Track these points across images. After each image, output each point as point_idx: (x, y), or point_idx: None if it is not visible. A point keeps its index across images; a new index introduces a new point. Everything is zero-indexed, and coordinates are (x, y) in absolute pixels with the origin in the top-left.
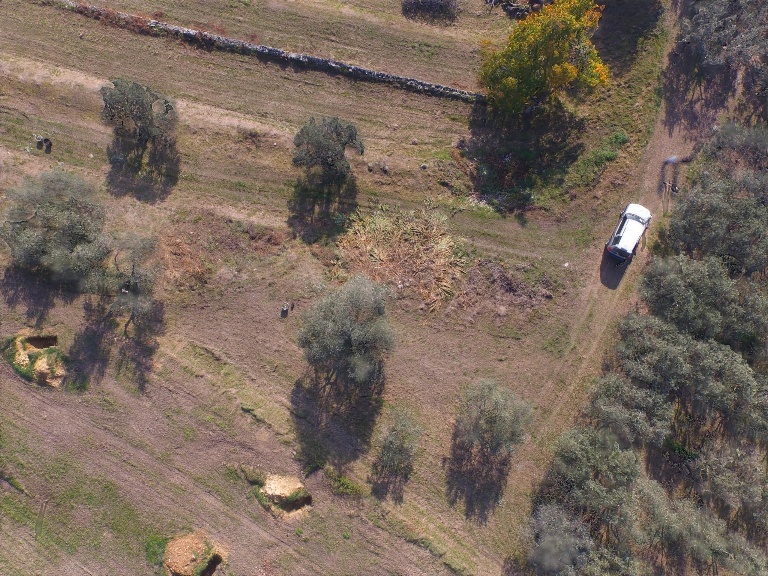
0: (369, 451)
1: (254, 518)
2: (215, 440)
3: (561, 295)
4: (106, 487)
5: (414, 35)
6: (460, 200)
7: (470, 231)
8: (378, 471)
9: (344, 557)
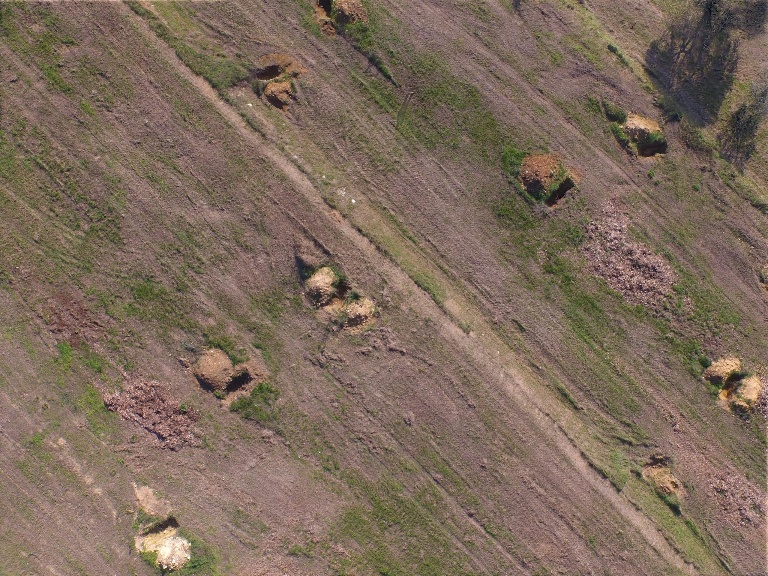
0: (715, 123)
1: (609, 152)
2: (580, 70)
3: None
4: (470, 92)
5: None
6: None
7: None
8: (721, 143)
9: (691, 207)
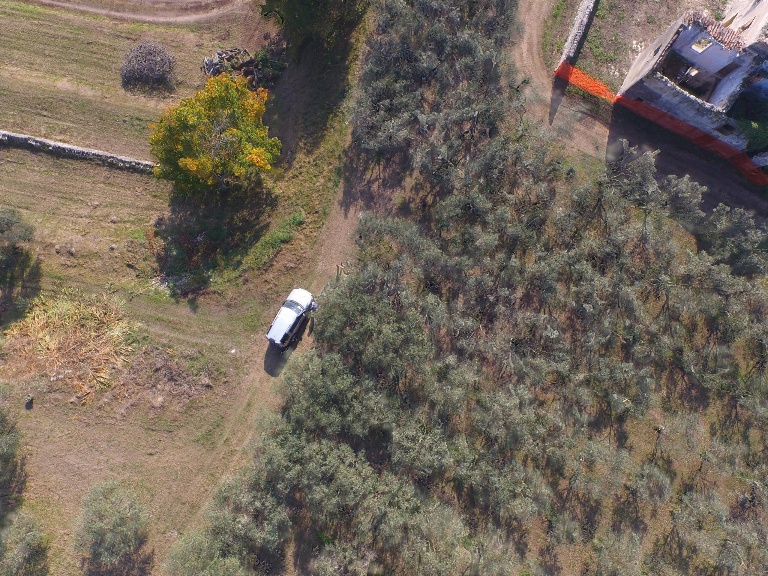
0: (4, 553)
1: None
2: None
3: (221, 384)
4: None
5: (126, 109)
6: (142, 283)
7: (146, 316)
8: (12, 574)
9: None
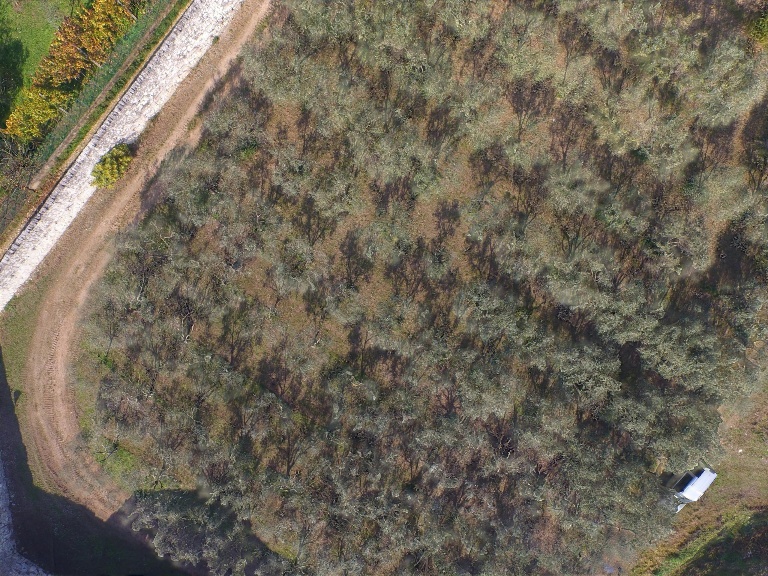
0: None
1: None
2: None
3: (760, 422)
4: None
5: None
6: None
7: None
8: None
9: None
